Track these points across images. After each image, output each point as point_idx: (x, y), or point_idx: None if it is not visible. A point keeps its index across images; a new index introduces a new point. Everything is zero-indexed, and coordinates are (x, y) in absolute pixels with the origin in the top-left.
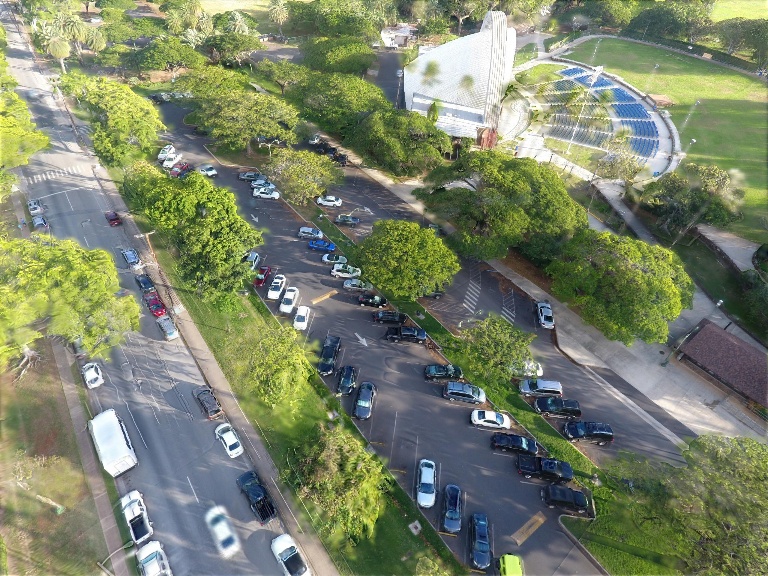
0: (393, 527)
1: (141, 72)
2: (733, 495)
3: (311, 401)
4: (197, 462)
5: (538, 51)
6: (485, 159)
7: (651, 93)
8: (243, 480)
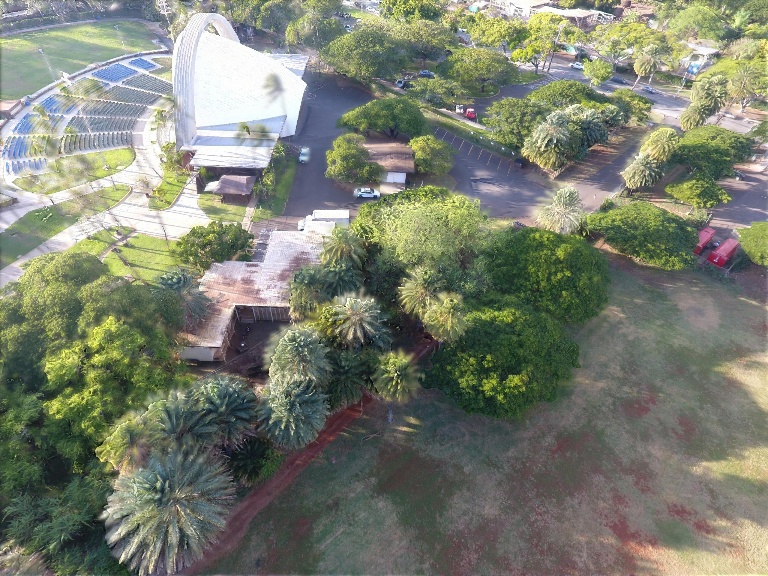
0: None
1: (614, 130)
2: None
3: (351, 14)
4: None
5: (3, 231)
6: None
7: None
8: (364, 5)
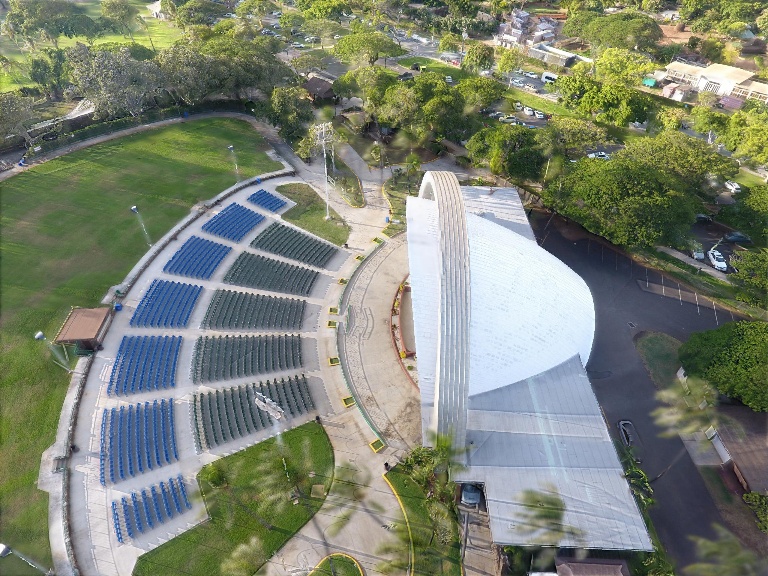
0: (457, 76)
1: None
2: (376, 40)
3: None
4: (523, 82)
5: None
6: (446, 89)
7: (62, 364)
8: None
